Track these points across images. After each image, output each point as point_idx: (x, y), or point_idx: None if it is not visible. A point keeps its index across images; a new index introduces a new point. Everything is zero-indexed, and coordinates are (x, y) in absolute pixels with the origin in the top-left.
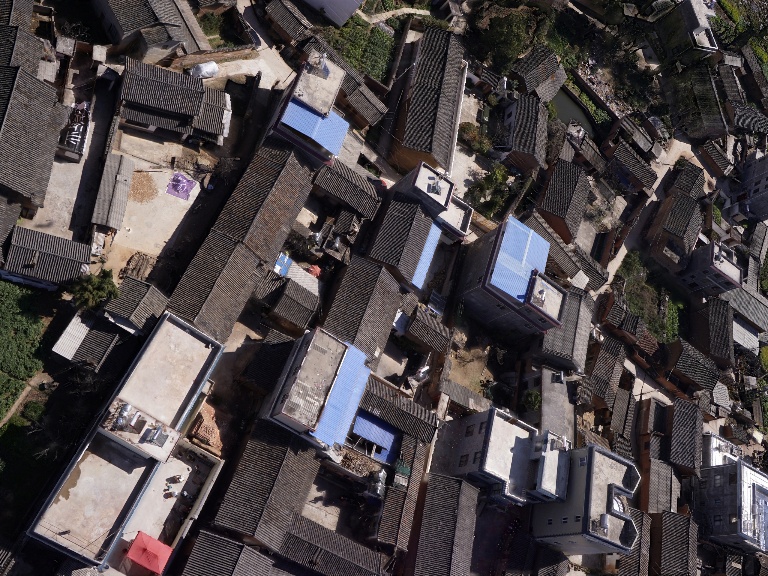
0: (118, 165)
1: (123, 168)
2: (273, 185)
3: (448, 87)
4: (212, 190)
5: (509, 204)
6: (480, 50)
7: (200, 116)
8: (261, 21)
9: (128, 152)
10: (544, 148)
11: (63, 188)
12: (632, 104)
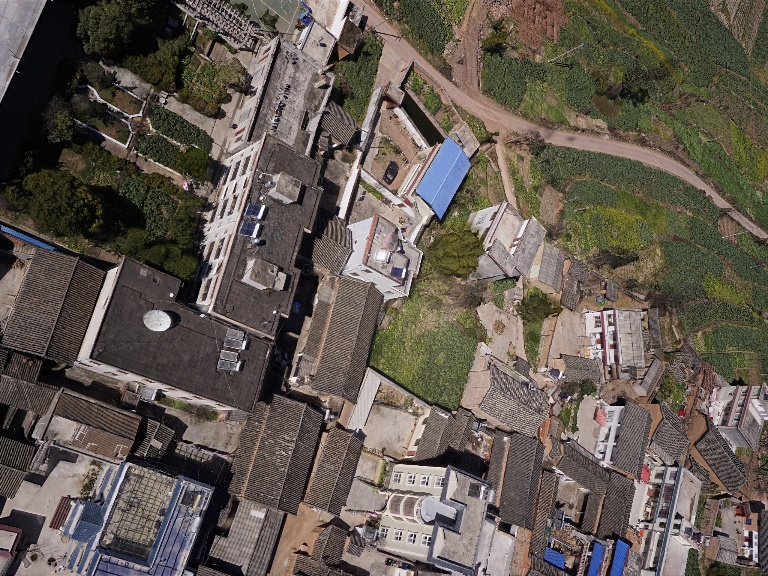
0: None
1: None
2: None
3: None
4: None
5: None
6: None
7: None
8: None
9: None
10: None
11: None
12: None
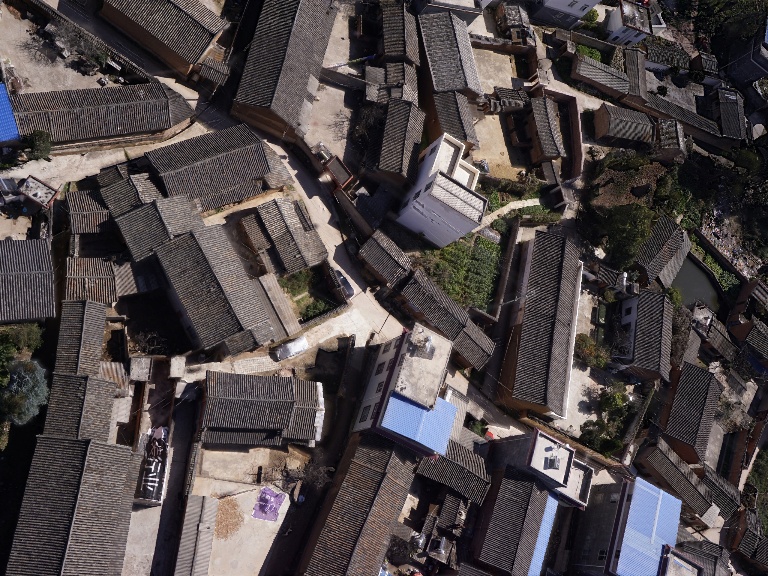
0: (200, 510)
1: (205, 512)
2: (372, 503)
3: (563, 308)
4: (303, 502)
5: (628, 423)
6: (595, 234)
7: (290, 423)
8: (354, 261)
9: (210, 473)
10: (669, 355)
11: (140, 543)
12: (762, 256)
